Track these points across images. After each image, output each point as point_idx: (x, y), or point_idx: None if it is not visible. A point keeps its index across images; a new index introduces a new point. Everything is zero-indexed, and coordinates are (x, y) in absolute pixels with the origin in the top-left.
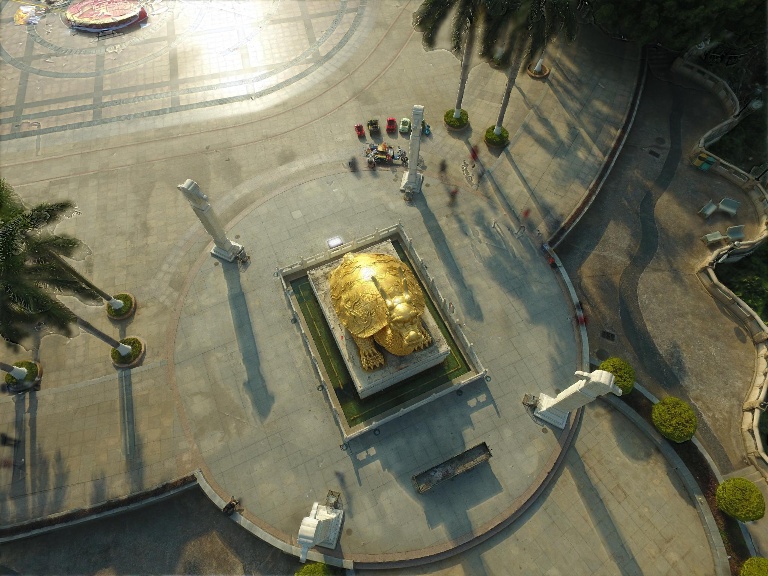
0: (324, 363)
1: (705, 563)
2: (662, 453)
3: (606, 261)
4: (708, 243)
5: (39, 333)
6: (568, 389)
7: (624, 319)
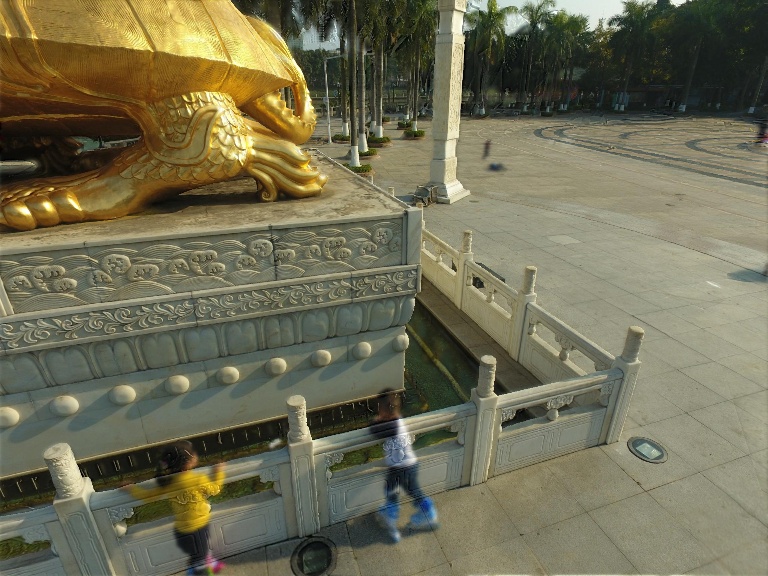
0: None
1: None
2: None
3: None
4: None
5: None
6: None
7: None
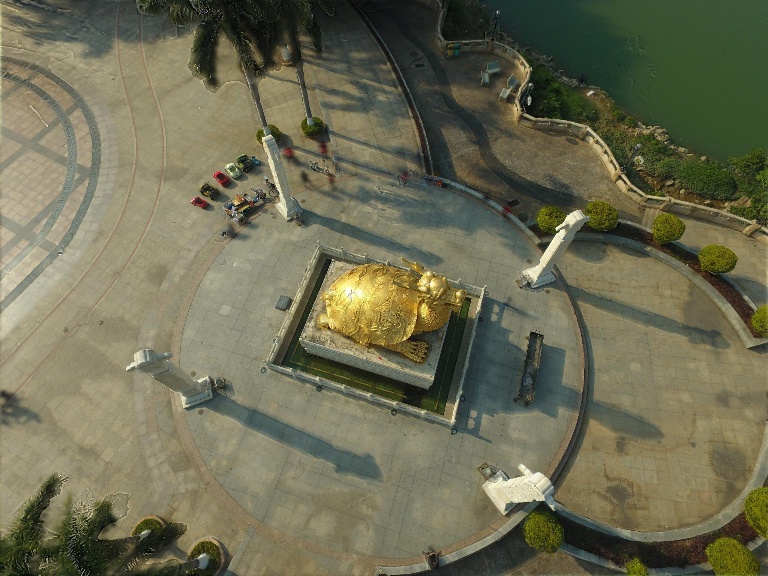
0: None
1: (682, 280)
2: (608, 243)
3: (465, 158)
4: (505, 100)
5: None
6: (550, 248)
7: (511, 185)
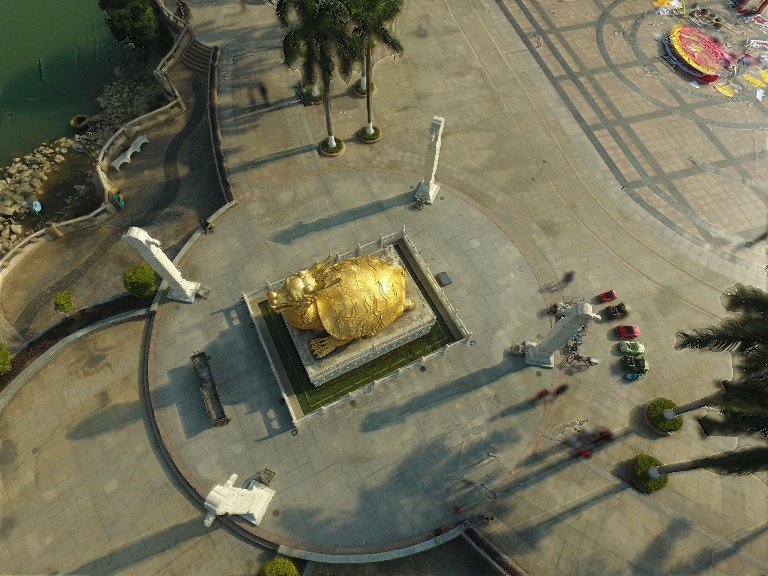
0: None
1: None
2: None
3: None
4: None
5: (294, 62)
6: (245, 491)
7: None
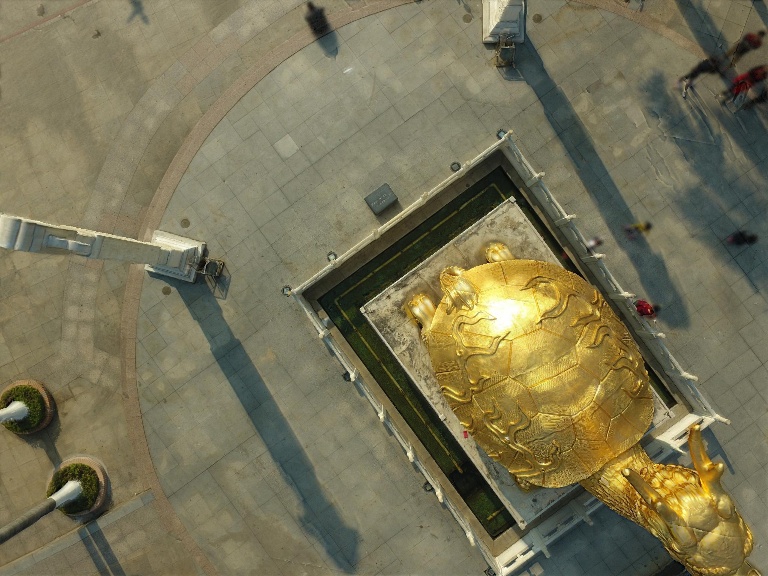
0: (420, 436)
1: None
2: None
3: None
4: None
5: None
6: None
7: None
